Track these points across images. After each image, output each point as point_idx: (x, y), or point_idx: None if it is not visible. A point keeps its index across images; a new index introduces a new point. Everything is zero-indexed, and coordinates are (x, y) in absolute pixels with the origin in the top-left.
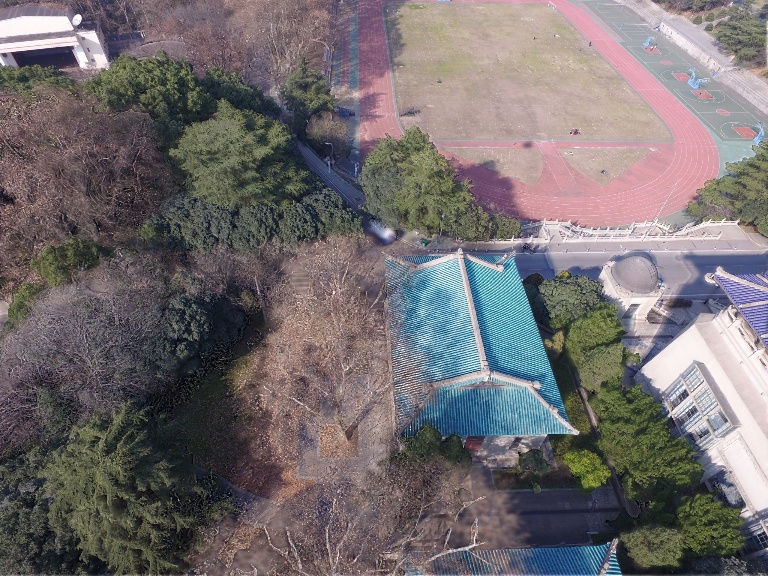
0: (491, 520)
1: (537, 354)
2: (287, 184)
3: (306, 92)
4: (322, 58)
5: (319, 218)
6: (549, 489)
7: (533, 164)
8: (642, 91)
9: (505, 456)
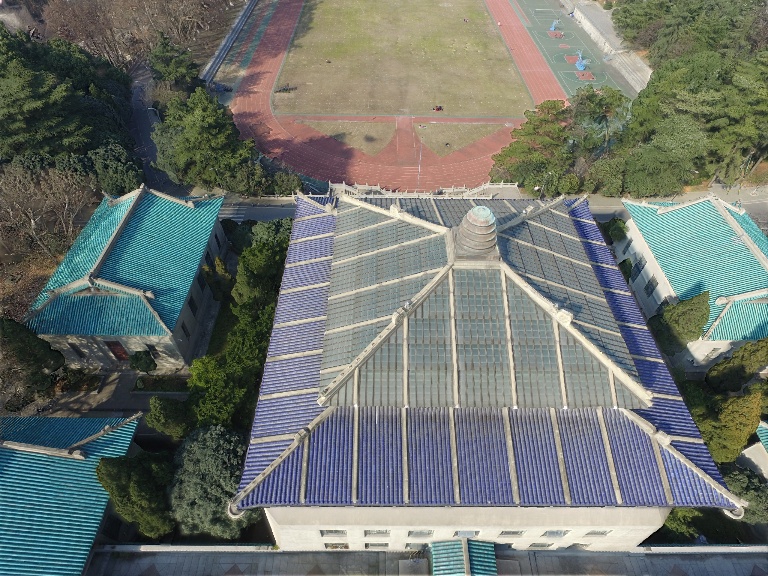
0: (115, 414)
1: (180, 273)
2: (67, 137)
3: (168, 66)
4: (222, 39)
5: (94, 169)
6: (180, 392)
7: (382, 137)
8: (525, 72)
9: (157, 366)
